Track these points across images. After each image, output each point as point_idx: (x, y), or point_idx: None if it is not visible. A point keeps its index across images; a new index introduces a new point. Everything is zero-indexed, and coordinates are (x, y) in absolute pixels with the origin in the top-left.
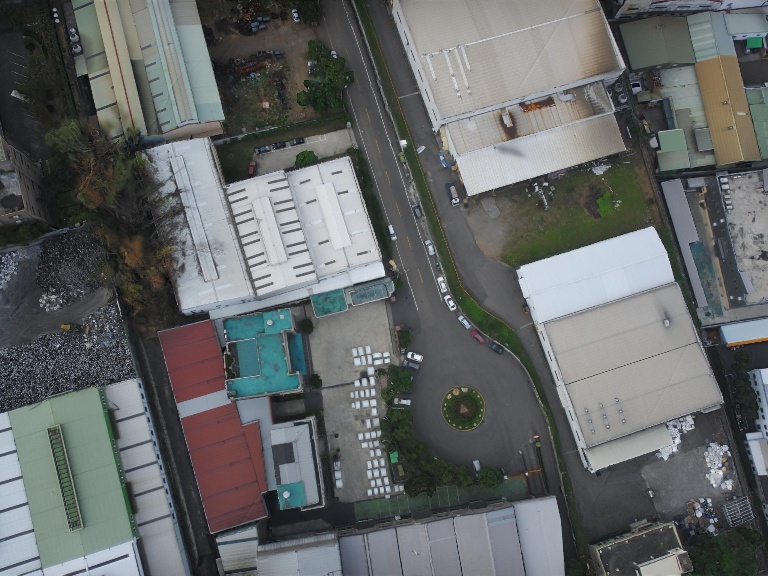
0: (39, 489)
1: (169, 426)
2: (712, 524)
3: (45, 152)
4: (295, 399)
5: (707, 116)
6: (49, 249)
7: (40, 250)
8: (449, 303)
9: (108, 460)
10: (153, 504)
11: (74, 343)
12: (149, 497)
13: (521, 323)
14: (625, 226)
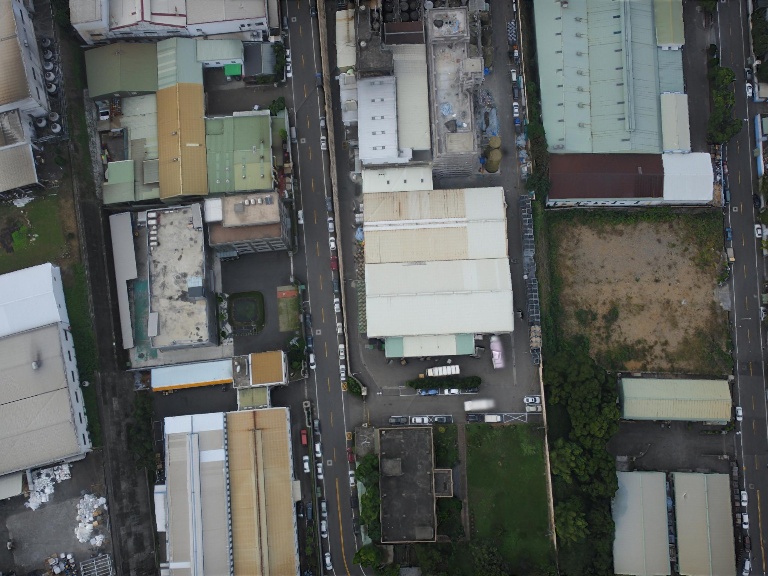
0: None
1: None
2: None
3: None
4: None
5: (159, 147)
6: None
7: None
8: None
9: None
10: None
11: None
12: None
13: None
14: (39, 261)
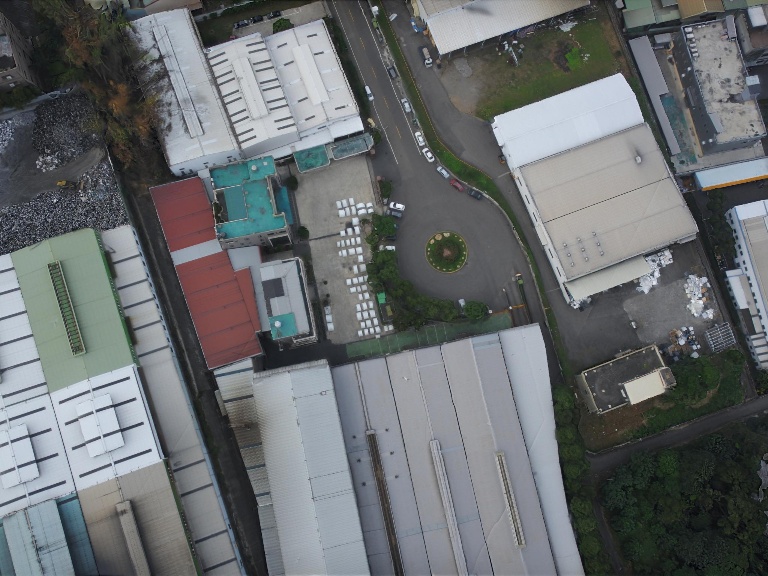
0: (43, 321)
1: (164, 275)
2: (695, 351)
3: (35, 29)
4: (284, 251)
5: None
6: (43, 114)
7: (34, 117)
8: (427, 155)
9: (106, 293)
10: (151, 337)
11: (70, 198)
12: (147, 331)
13: (498, 173)
14: (594, 78)
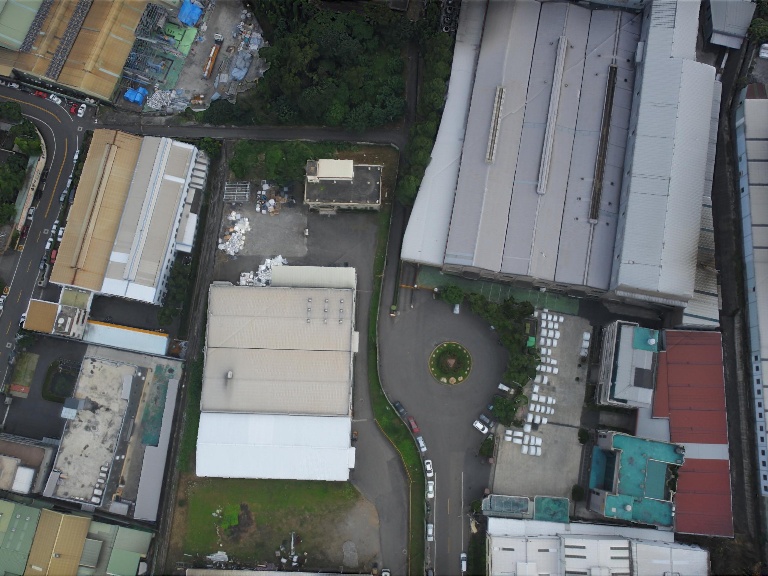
0: None
1: (738, 441)
2: (263, 190)
3: None
4: (607, 426)
5: None
6: None
7: None
8: (431, 468)
9: None
10: None
11: None
12: None
13: (364, 424)
14: (220, 487)
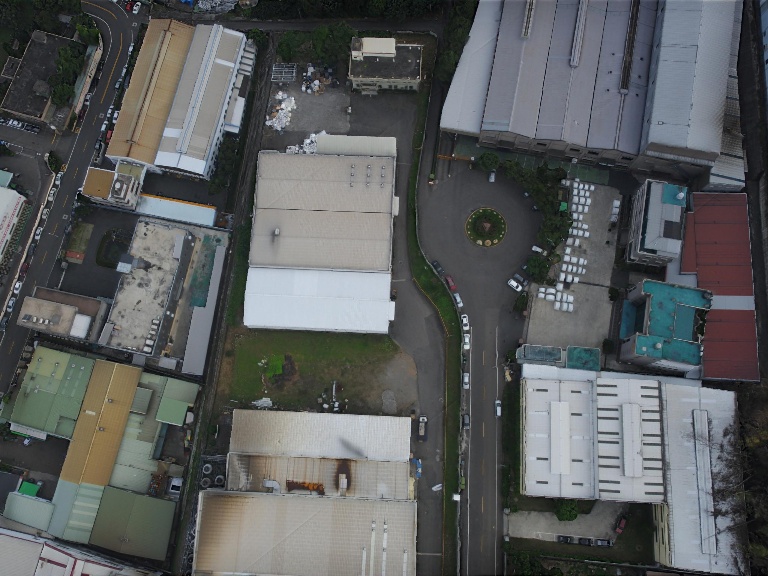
0: None
1: (764, 295)
2: None
3: None
4: None
5: (125, 424)
6: None
7: None
8: (467, 322)
9: None
10: None
11: None
12: None
13: (403, 284)
14: (265, 339)
